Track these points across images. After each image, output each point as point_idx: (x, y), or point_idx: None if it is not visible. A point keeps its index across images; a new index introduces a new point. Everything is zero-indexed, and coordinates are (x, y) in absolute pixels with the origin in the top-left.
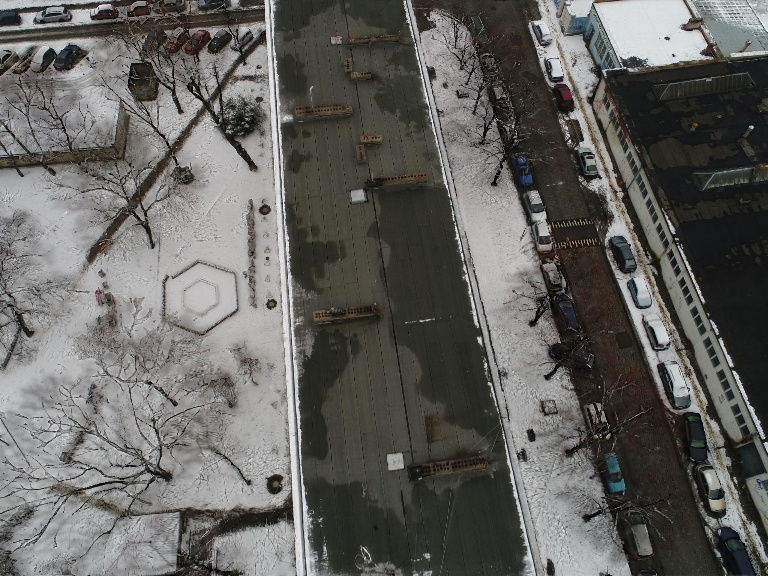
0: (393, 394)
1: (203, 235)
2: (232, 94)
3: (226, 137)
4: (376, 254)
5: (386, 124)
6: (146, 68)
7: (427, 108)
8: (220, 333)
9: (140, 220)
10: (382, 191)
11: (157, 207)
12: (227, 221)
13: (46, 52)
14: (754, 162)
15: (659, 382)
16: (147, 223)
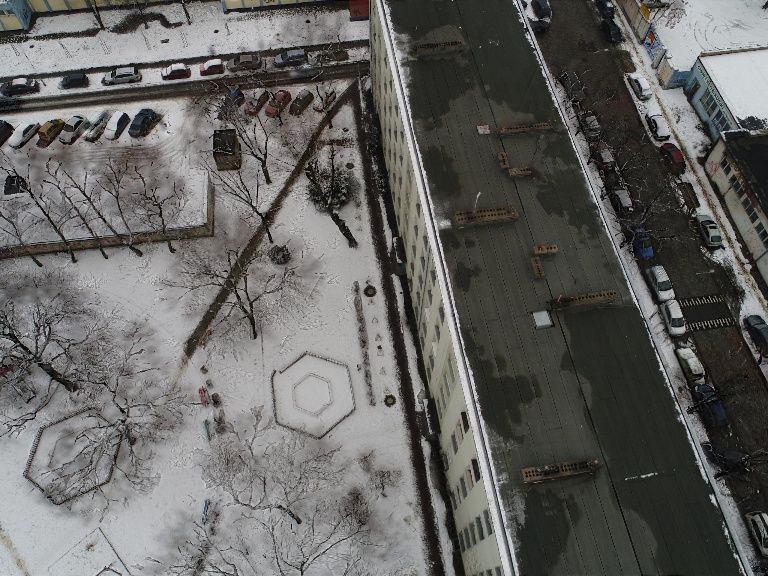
0: (630, 573)
1: (307, 322)
2: (320, 160)
3: (332, 217)
4: (576, 392)
5: (556, 229)
6: (231, 136)
7: (596, 208)
8: (338, 436)
9: (247, 312)
10: (567, 312)
11: (266, 299)
12: (331, 305)
13: (120, 118)
14: None
15: None
16: (252, 314)
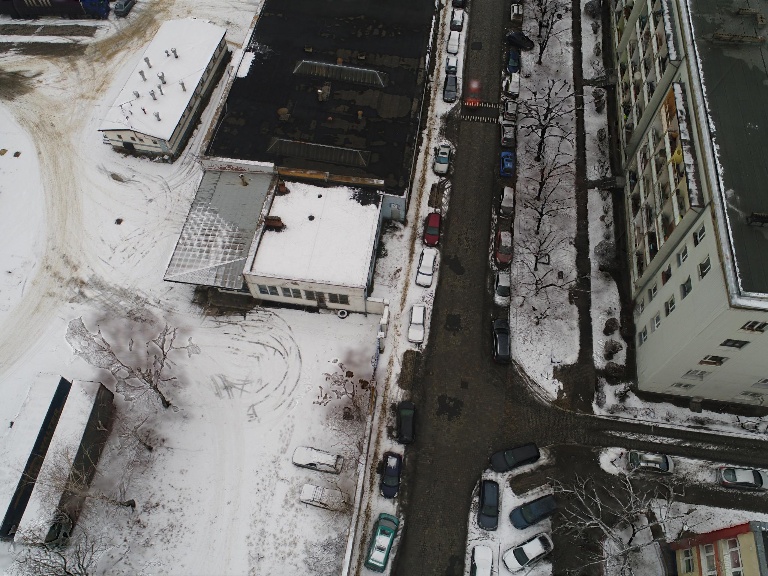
0: None
1: None
2: None
3: None
4: None
5: None
6: None
7: None
8: None
9: None
10: None
11: None
12: None
13: None
14: (330, 81)
15: (465, 24)
16: None
